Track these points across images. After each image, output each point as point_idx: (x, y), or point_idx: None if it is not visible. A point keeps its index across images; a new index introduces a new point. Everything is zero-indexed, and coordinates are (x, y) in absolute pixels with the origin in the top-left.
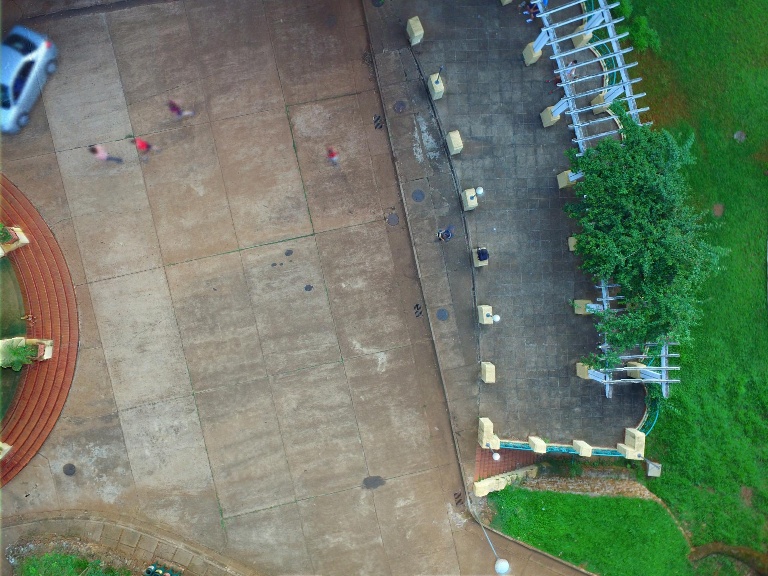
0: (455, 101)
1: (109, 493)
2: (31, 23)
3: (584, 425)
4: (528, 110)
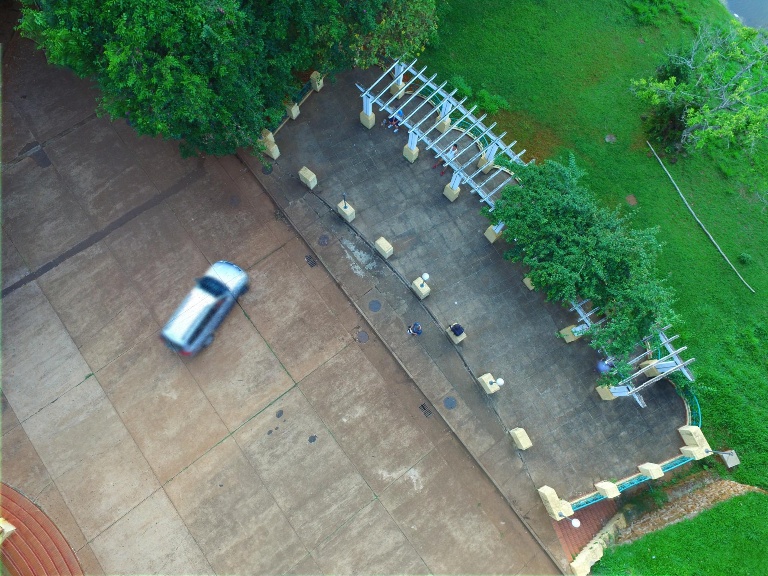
0: (368, 215)
1: None
2: None
3: (639, 446)
4: (432, 195)
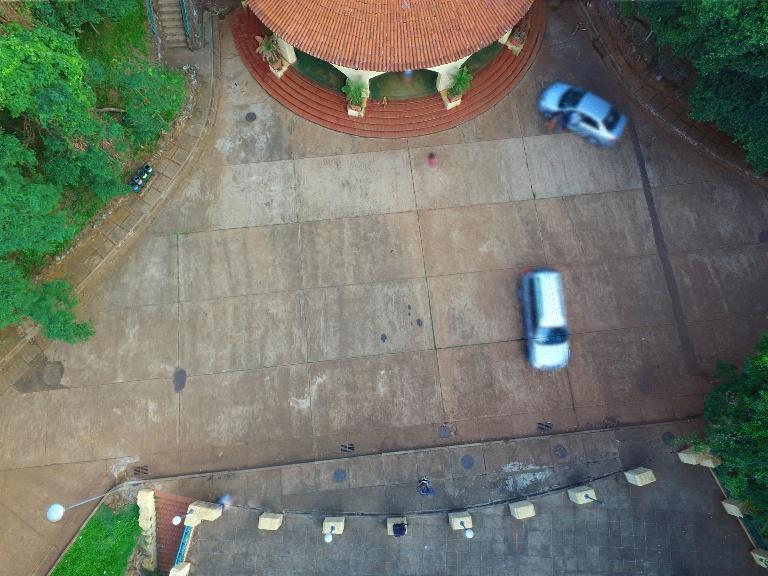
0: (567, 515)
1: (224, 145)
2: (632, 132)
3: None
4: None
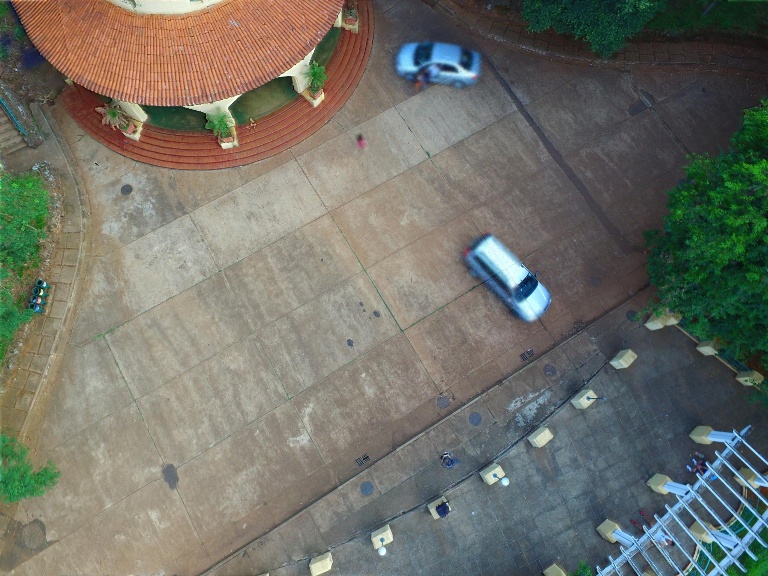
0: (579, 423)
1: (111, 228)
2: (486, 63)
3: None
4: (605, 504)
